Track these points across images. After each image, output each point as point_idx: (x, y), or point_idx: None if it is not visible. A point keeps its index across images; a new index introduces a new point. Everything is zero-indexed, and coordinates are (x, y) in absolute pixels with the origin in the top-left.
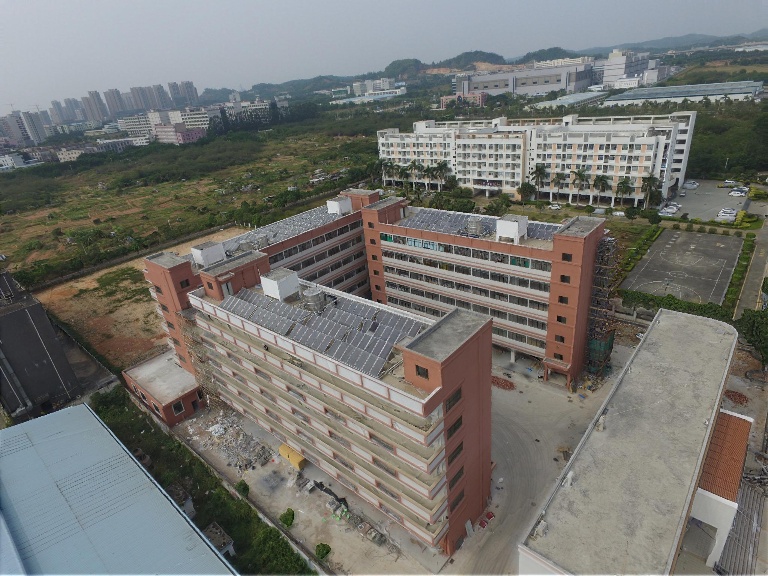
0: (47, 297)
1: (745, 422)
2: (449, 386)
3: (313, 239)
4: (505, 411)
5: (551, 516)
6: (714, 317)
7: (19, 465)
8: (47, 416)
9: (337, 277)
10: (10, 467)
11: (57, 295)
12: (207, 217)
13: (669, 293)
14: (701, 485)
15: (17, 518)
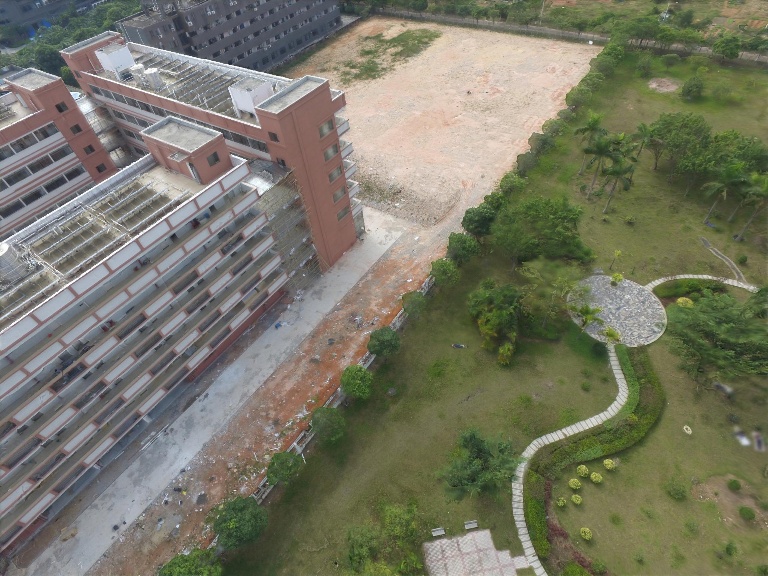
0: (368, 26)
1: None
2: None
3: None
4: None
5: None
6: None
7: None
8: None
9: None
10: None
11: (372, 28)
12: (642, 11)
13: None
14: None
15: None
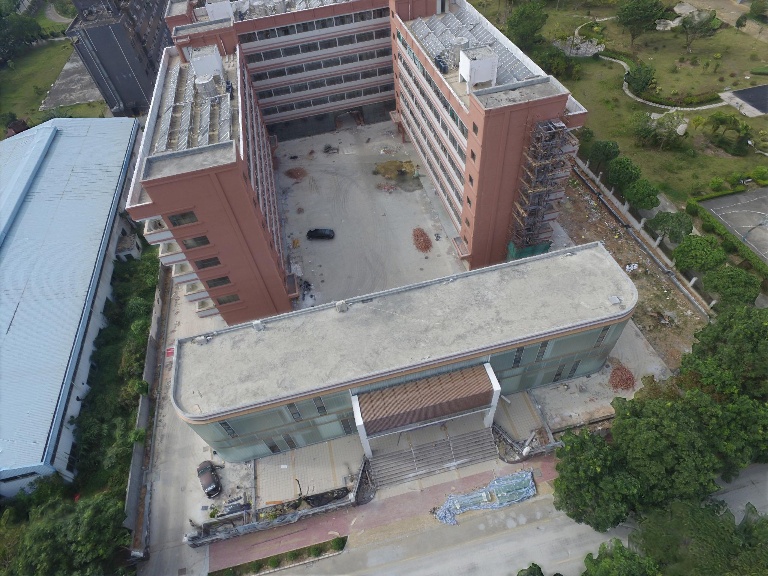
0: None
1: (487, 386)
2: (169, 206)
3: (336, 17)
4: (391, 265)
5: (220, 338)
6: (721, 289)
7: (69, 146)
8: (109, 119)
9: (367, 69)
10: (64, 145)
11: None
12: None
13: (763, 238)
14: (361, 396)
15: (41, 177)
